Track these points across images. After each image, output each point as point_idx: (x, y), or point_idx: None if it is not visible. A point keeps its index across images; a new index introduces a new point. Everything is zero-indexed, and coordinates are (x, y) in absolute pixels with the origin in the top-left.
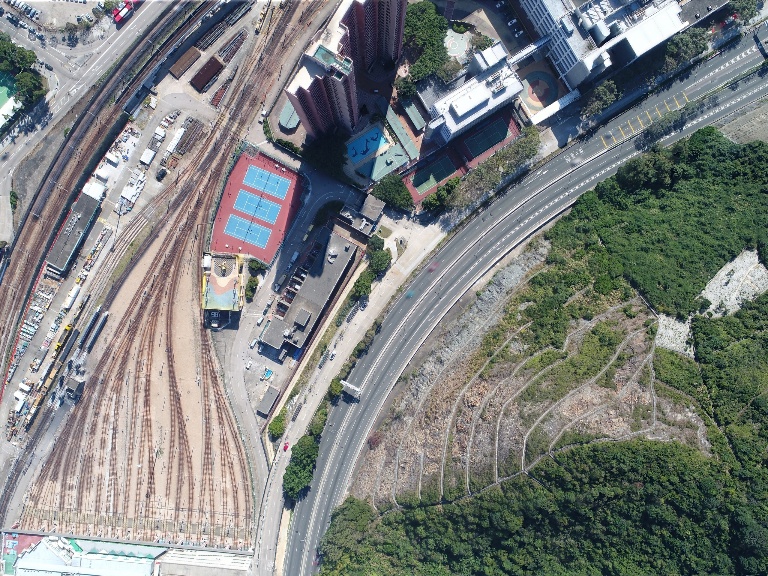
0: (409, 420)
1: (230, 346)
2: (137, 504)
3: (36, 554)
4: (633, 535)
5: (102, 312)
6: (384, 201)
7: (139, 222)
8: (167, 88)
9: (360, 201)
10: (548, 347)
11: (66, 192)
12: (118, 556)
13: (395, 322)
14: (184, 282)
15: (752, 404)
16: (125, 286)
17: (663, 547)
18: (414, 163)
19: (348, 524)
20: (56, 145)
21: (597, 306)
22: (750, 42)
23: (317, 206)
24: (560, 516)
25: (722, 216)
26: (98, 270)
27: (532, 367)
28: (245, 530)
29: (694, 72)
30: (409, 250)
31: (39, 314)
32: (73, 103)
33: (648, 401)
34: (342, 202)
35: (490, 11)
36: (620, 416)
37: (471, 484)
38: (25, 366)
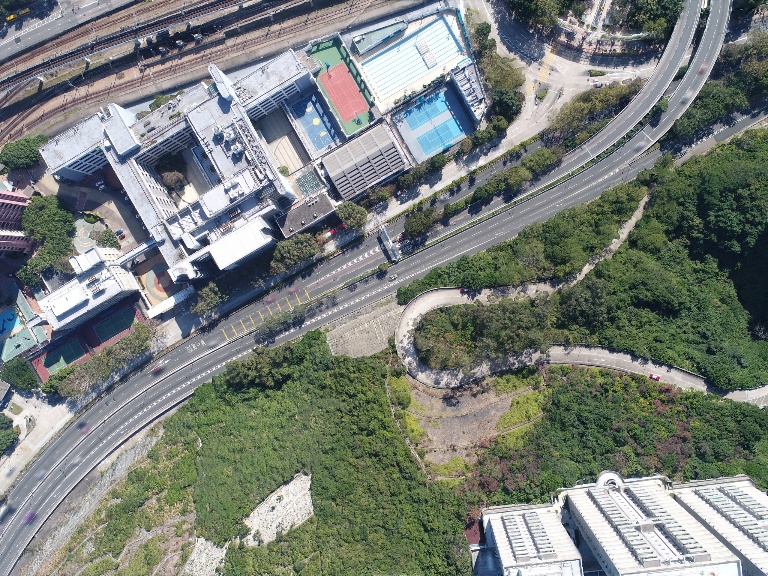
0: None
1: None
2: None
3: None
4: None
5: None
6: (9, 383)
7: None
8: None
9: None
10: (108, 554)
11: None
12: None
13: (21, 496)
14: None
15: None
16: None
17: None
18: (44, 345)
19: None
20: None
21: (158, 517)
22: (373, 243)
23: None
24: None
25: (296, 432)
26: None
27: (88, 574)
28: None
29: (316, 270)
30: (38, 428)
31: None
32: None
33: None
34: None
35: (120, 203)
36: None
37: None
38: None
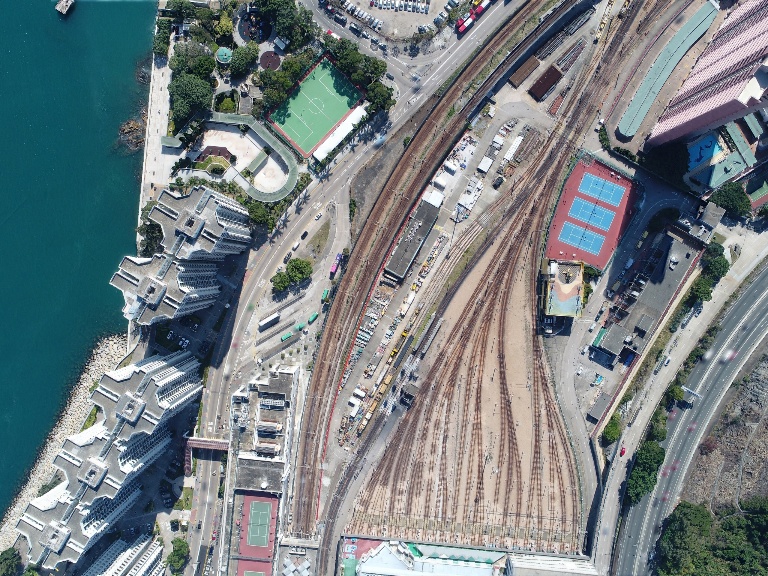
0: (754, 426)
1: (561, 352)
2: (466, 509)
3: (379, 558)
4: None
5: (436, 318)
6: (724, 208)
7: (474, 229)
8: (505, 97)
9: (694, 208)
10: None
11: (407, 200)
12: (457, 561)
13: (729, 328)
14: (517, 289)
15: None
16: (459, 293)
17: None
18: (749, 170)
19: (694, 529)
20: (395, 153)
21: None
22: None
23: (651, 213)
24: None
25: None
26: (433, 277)
27: None
28: (572, 535)
29: None
30: (743, 257)
31: (374, 320)
32: (412, 112)
33: None
34: (677, 209)
35: None
36: None
37: None
38: (359, 372)
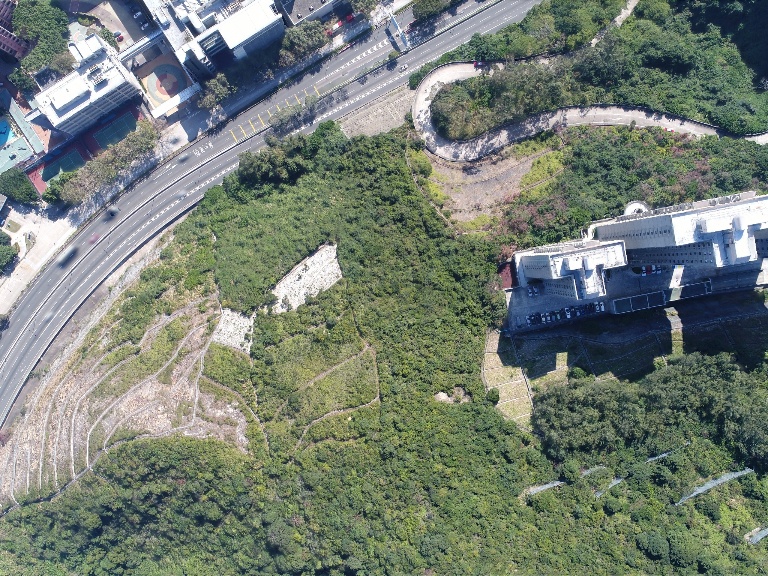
0: (26, 416)
1: None
2: None
3: None
4: (195, 533)
5: None
6: (6, 195)
7: None
8: None
9: None
10: (127, 342)
11: None
12: None
13: (24, 317)
14: None
15: (288, 400)
16: None
17: (220, 545)
18: (42, 157)
19: None
20: None
21: (178, 301)
22: (382, 35)
23: None
24: (130, 513)
25: (316, 210)
26: None
27: (108, 363)
28: None
29: (325, 65)
30: (38, 245)
31: None
32: None
33: (191, 397)
34: None
35: (116, 4)
36: (166, 412)
37: (57, 481)
38: None
